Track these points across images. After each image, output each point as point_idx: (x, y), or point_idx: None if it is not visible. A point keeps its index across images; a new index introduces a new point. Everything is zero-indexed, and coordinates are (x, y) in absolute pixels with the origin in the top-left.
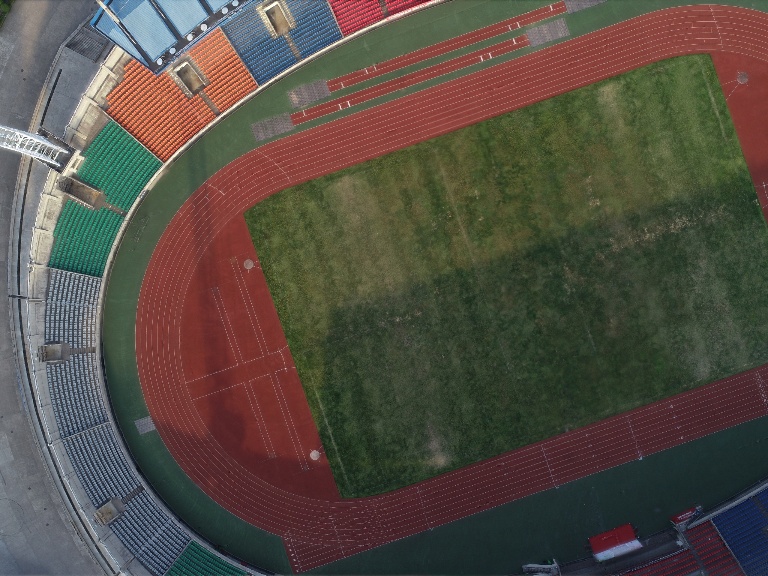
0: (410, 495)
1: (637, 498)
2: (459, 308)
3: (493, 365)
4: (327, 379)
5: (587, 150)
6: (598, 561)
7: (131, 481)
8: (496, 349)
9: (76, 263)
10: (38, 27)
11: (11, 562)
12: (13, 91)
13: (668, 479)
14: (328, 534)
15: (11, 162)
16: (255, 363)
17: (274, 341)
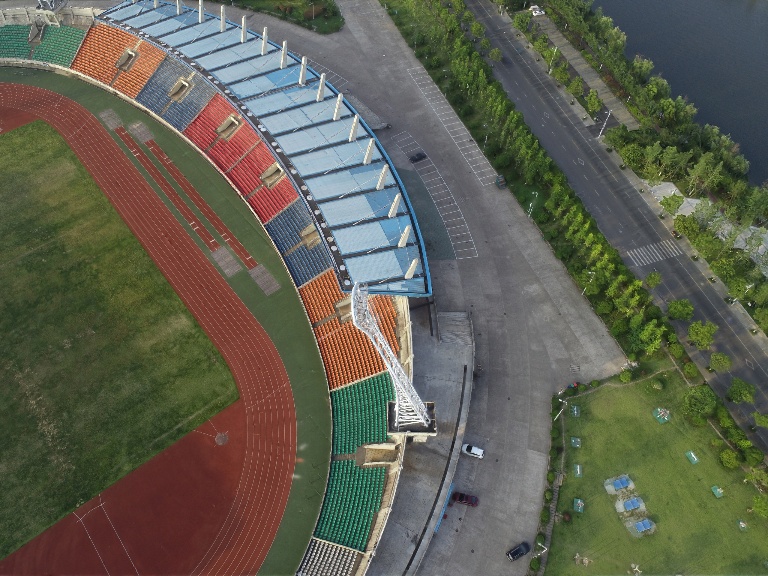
0: None
1: None
2: None
3: None
4: None
5: (120, 322)
6: None
7: None
8: None
9: None
10: None
11: None
12: None
13: None
14: None
15: None
16: None
17: None
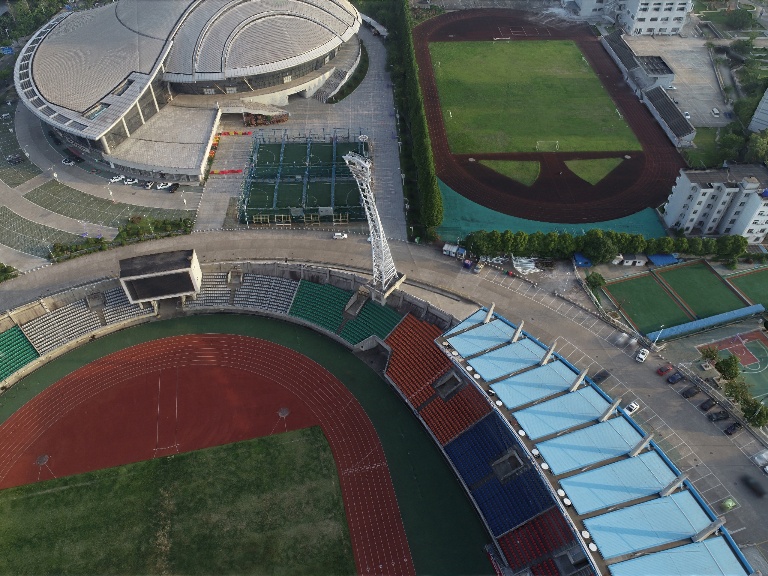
0: None
1: None
2: None
3: None
4: None
5: None
6: None
7: None
8: None
9: None
10: None
11: None
12: None
13: None
14: None
15: None
16: None
17: None
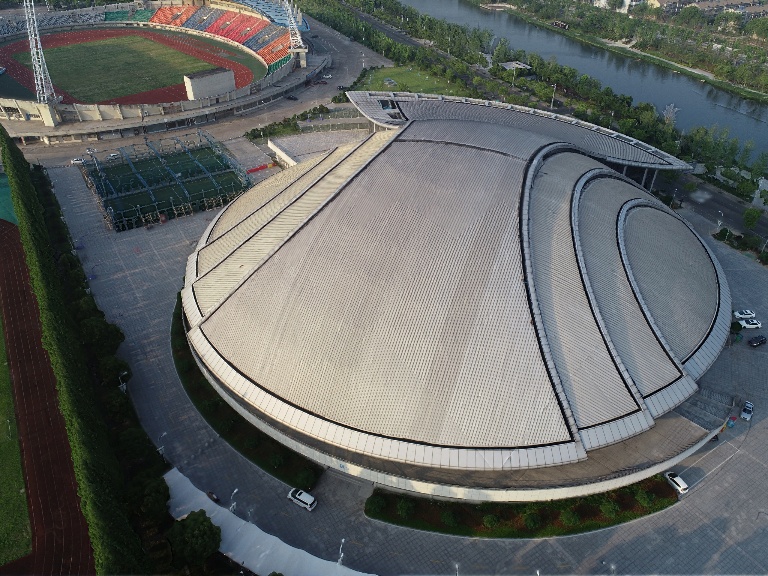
0: None
1: None
2: None
3: None
4: None
5: None
6: None
7: None
8: None
9: None
10: None
11: None
12: None
13: None
14: None
15: None
16: None
17: None
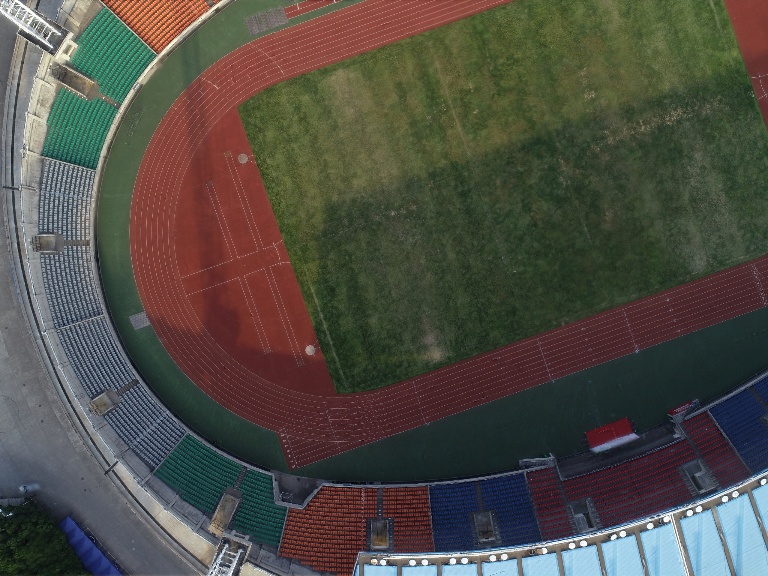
0: (406, 390)
1: (634, 392)
2: (454, 201)
3: (488, 259)
4: (322, 273)
5: (582, 42)
6: (595, 455)
7: (126, 374)
8: (491, 242)
9: (70, 154)
10: None
11: (6, 459)
12: None
13: (665, 373)
14: (324, 429)
15: (4, 57)
16: (250, 258)
17: (269, 235)
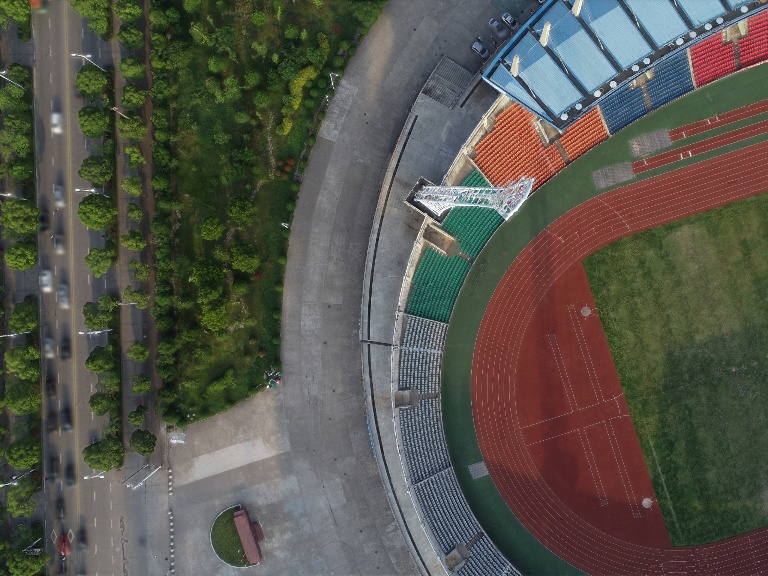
0: (741, 544)
1: None
2: None
3: None
4: (661, 427)
5: None
6: None
7: (472, 527)
8: None
9: (427, 309)
10: (382, 71)
11: None
12: (355, 134)
13: None
14: None
15: (351, 205)
16: (590, 410)
17: (609, 389)
